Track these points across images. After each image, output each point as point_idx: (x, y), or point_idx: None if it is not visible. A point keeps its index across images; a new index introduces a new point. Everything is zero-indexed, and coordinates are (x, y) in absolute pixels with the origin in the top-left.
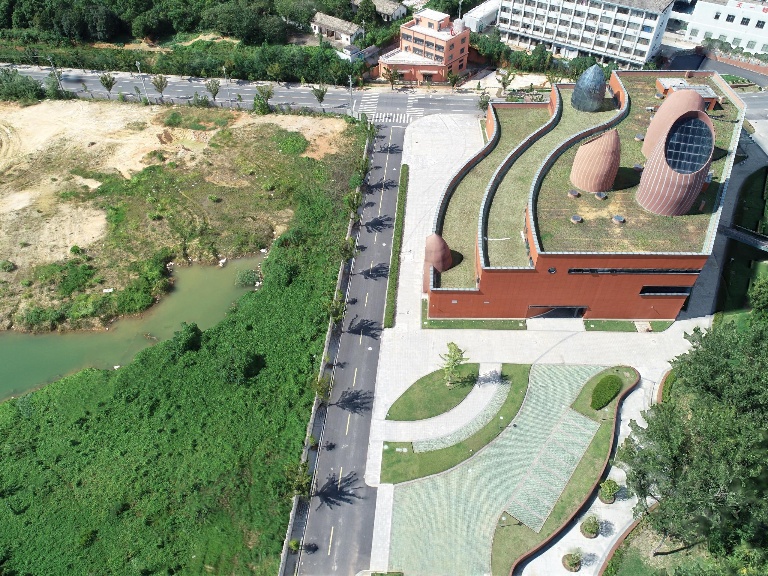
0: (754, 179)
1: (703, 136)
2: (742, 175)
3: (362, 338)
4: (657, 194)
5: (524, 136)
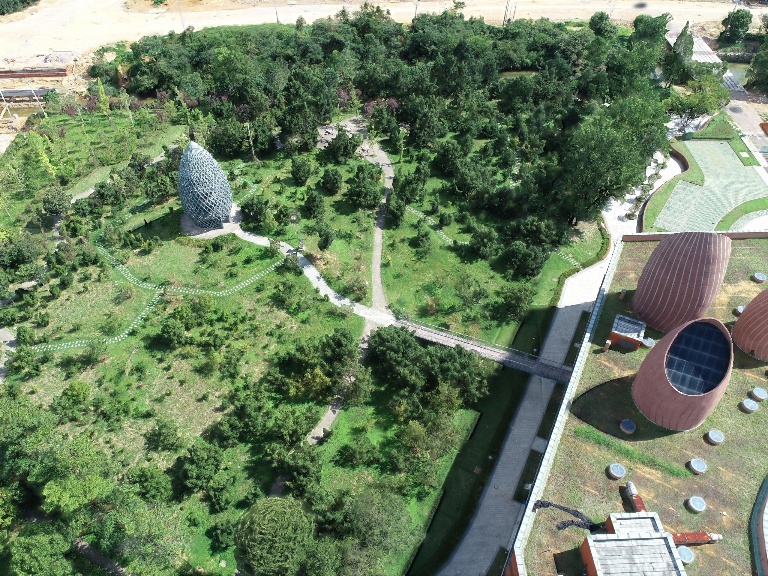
0: (440, 549)
1: None
2: (453, 572)
3: None
4: None
5: None
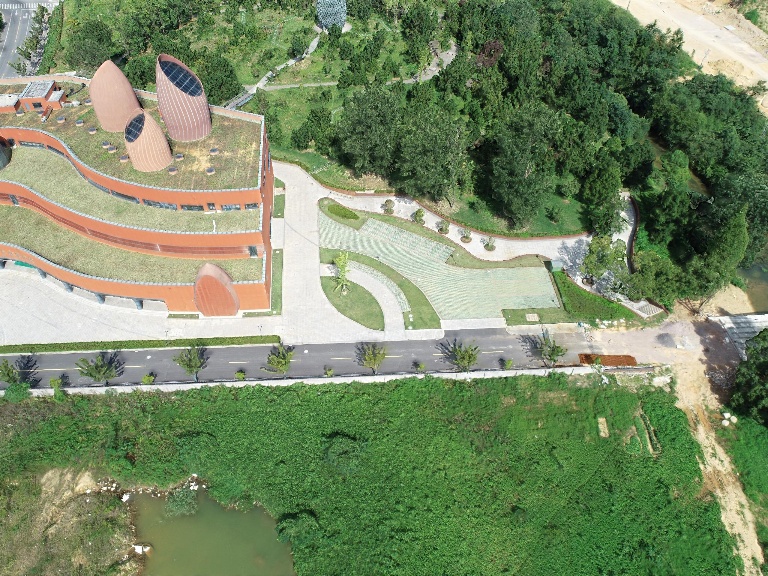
0: None
1: (176, 68)
2: None
3: (293, 359)
4: (201, 121)
5: (6, 224)
